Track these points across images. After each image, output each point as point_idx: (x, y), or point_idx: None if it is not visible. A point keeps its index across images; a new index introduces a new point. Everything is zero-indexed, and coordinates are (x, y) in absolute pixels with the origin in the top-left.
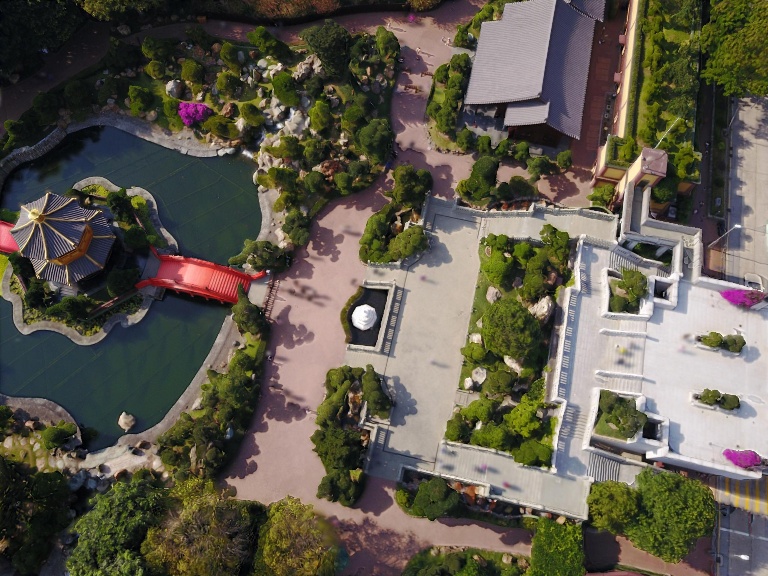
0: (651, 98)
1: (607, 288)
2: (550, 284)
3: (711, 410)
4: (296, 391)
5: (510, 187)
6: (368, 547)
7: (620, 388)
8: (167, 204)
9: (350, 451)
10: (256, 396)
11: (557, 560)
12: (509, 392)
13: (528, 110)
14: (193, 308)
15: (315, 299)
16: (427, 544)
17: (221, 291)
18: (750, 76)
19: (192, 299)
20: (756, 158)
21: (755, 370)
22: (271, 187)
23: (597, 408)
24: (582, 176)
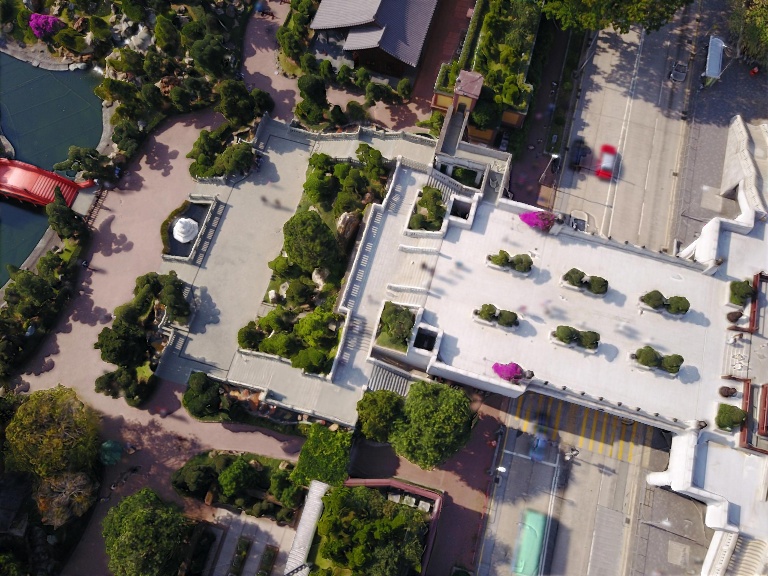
0: (488, 29)
1: (412, 207)
2: (363, 203)
3: (491, 327)
4: (106, 296)
5: (347, 113)
6: (149, 447)
7: (407, 302)
8: (12, 113)
9: (125, 345)
10: (63, 298)
11: (320, 464)
12: (312, 307)
13: (366, 35)
14: (23, 215)
15: (140, 210)
16: (208, 447)
17: (44, 195)
18: (579, 8)
19: (24, 206)
20: (603, 101)
21: (543, 292)
22: (108, 99)
23: (379, 319)
24: (425, 108)
